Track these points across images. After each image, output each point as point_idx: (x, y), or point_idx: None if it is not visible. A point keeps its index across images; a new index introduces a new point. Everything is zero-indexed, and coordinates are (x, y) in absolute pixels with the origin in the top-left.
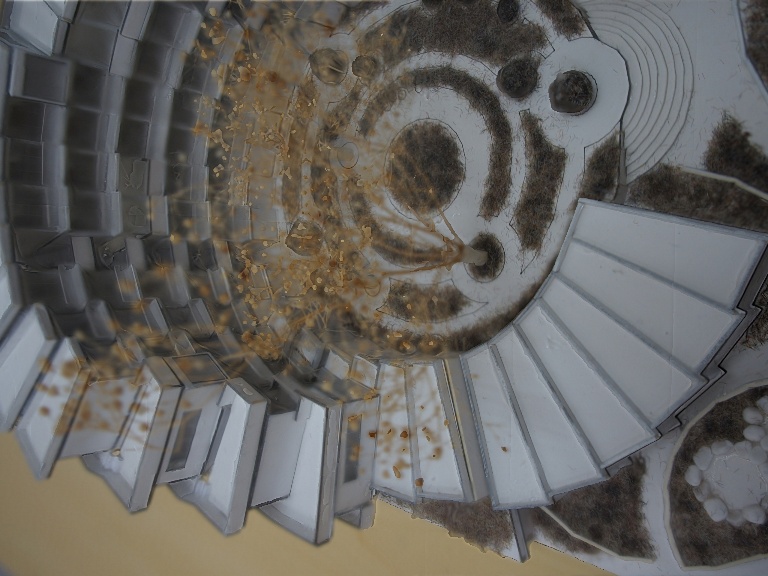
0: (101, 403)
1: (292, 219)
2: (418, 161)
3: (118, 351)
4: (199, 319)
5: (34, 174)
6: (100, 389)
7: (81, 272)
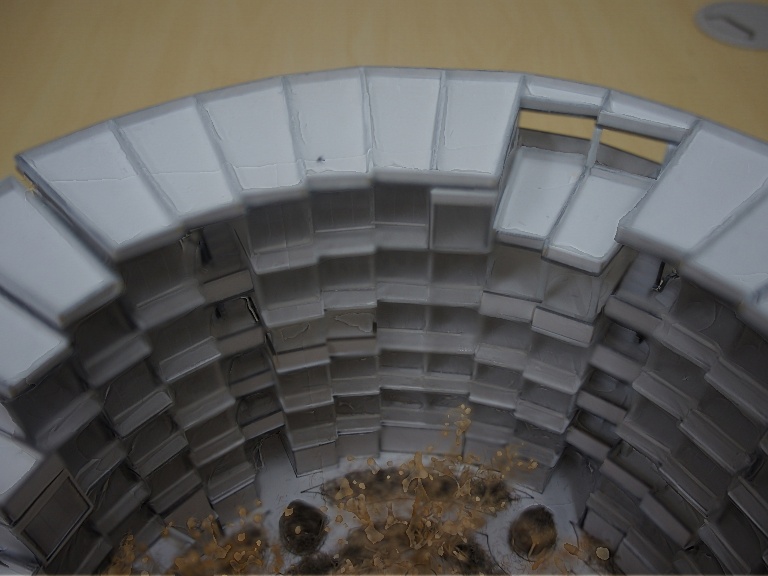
0: None
1: (328, 495)
2: None
3: (72, 389)
4: None
5: (329, 216)
6: None
7: (192, 308)
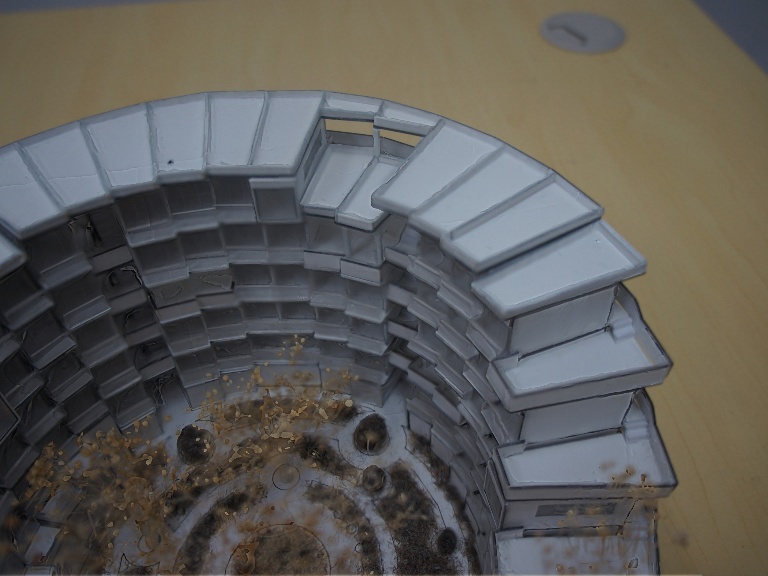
0: None
1: (216, 421)
2: (286, 567)
3: None
4: (68, 384)
5: (182, 203)
6: None
7: (83, 273)
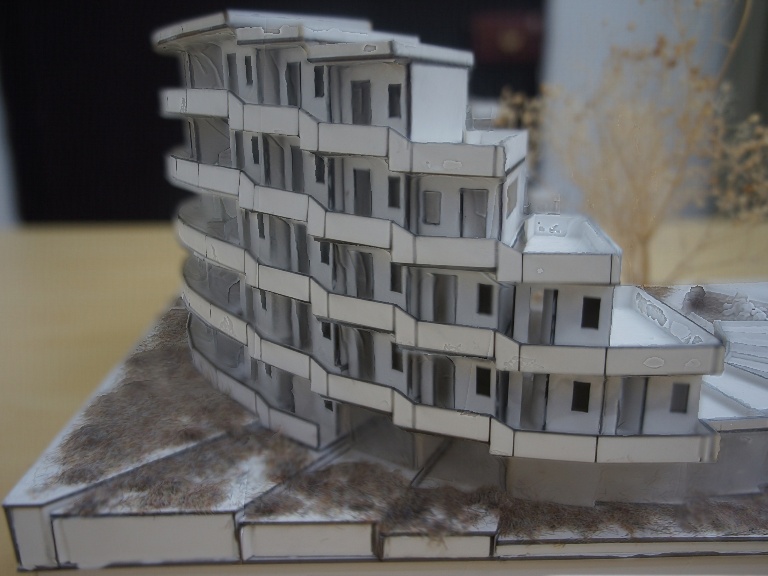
0: (449, 100)
1: None
2: None
3: None
4: None
5: None
6: (456, 92)
7: None
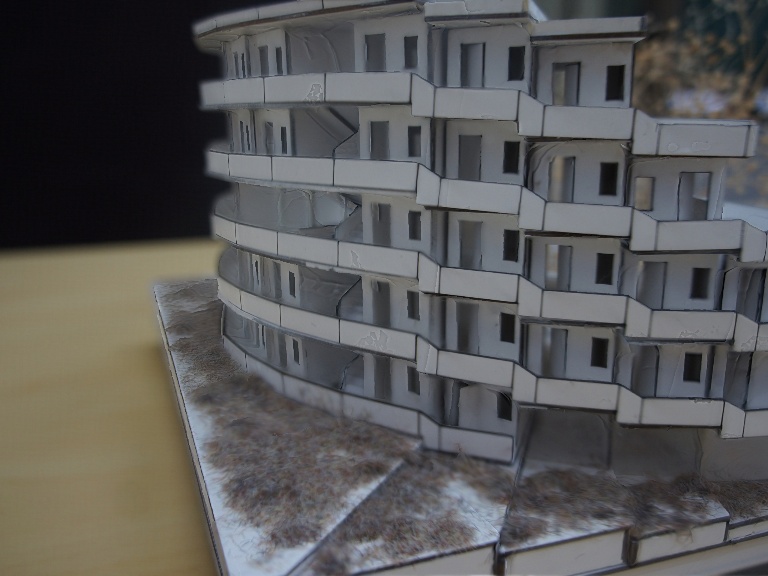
0: None
1: None
2: None
3: None
4: None
5: None
6: None
7: None
